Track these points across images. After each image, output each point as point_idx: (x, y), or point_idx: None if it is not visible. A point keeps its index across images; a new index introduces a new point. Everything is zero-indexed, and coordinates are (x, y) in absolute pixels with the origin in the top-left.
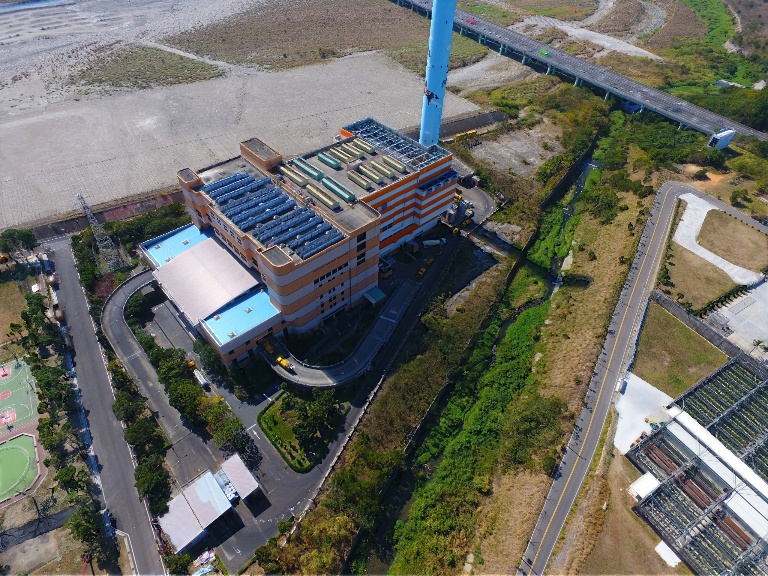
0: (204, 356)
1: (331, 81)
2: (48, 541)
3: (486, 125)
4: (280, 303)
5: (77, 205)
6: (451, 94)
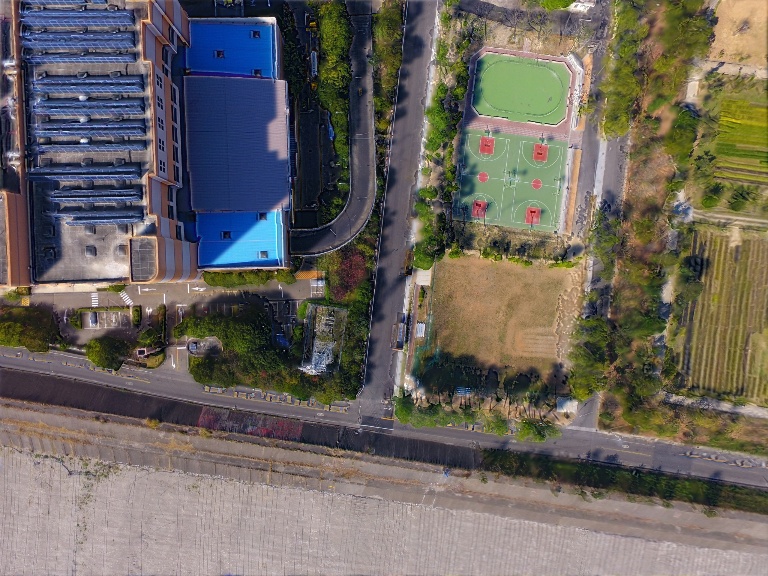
0: None
1: None
2: None
3: None
4: (180, 6)
5: None
6: None
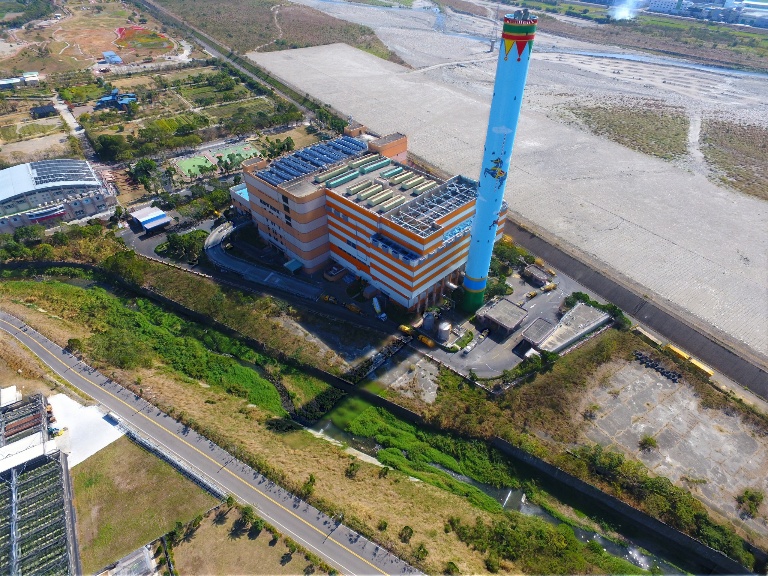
0: None
1: (743, 224)
2: None
3: (766, 399)
4: None
5: None
6: None
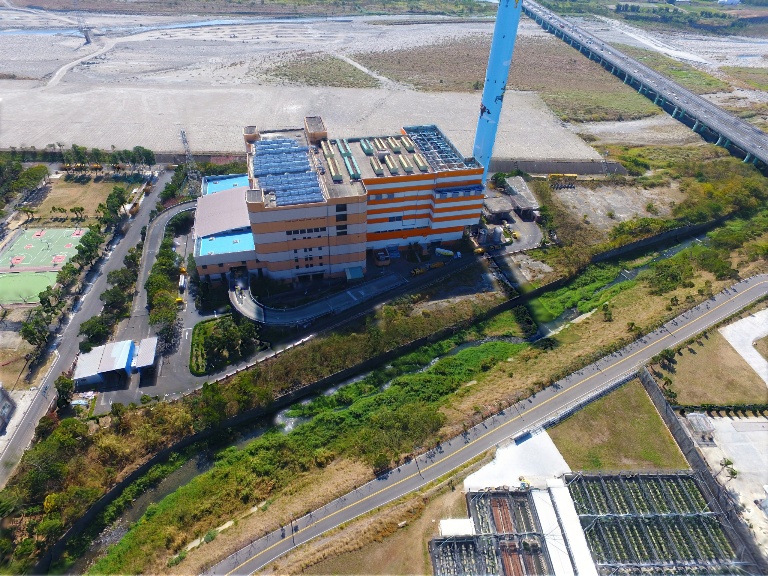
0: (188, 264)
1: (466, 107)
2: (19, 337)
3: (595, 174)
4: (254, 240)
5: None
6: (580, 140)
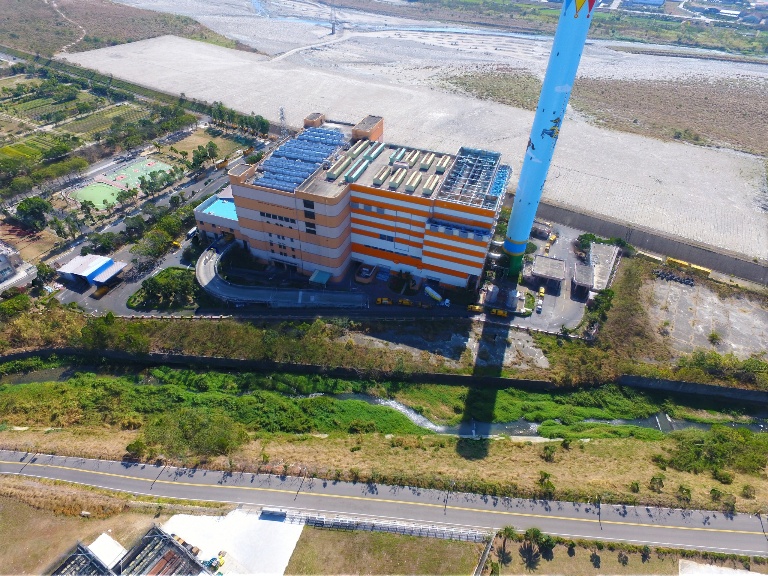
0: None
1: (637, 154)
2: None
3: (749, 280)
4: None
5: (279, 113)
6: None
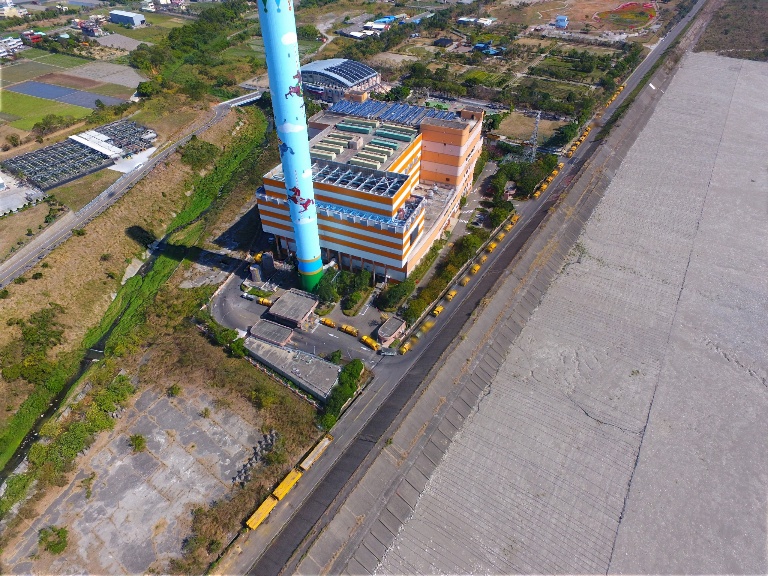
0: None
1: None
2: None
3: None
4: None
5: None
6: None
